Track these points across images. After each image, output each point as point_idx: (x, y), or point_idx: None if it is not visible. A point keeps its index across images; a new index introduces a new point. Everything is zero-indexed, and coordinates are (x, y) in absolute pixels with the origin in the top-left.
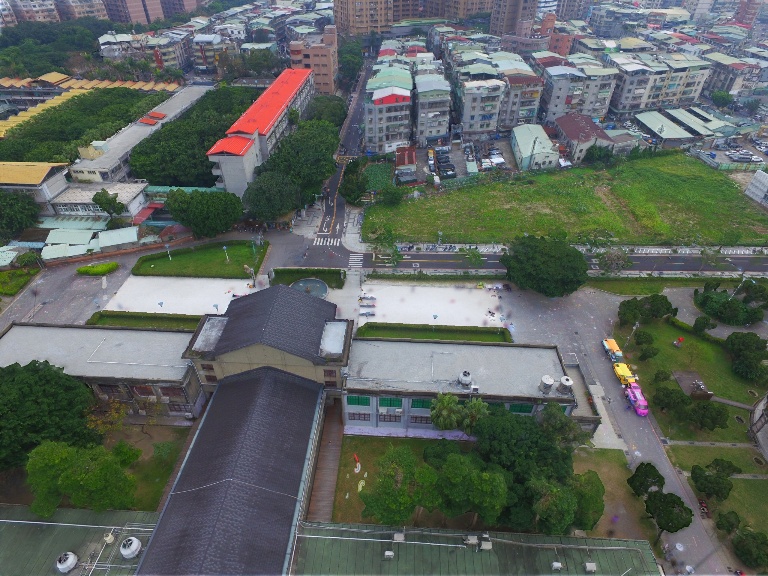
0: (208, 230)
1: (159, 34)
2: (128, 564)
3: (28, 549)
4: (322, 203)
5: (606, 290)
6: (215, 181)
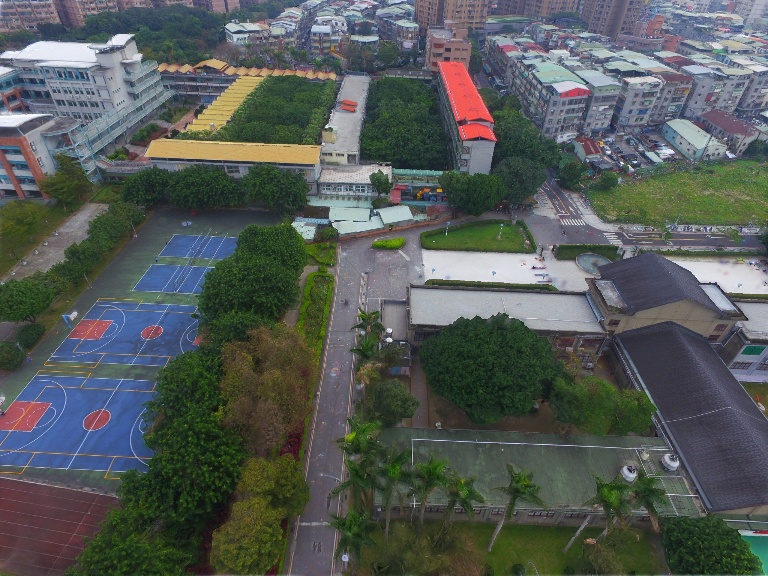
0: (482, 209)
1: None
2: (673, 475)
3: (580, 465)
4: (538, 188)
5: None
6: None
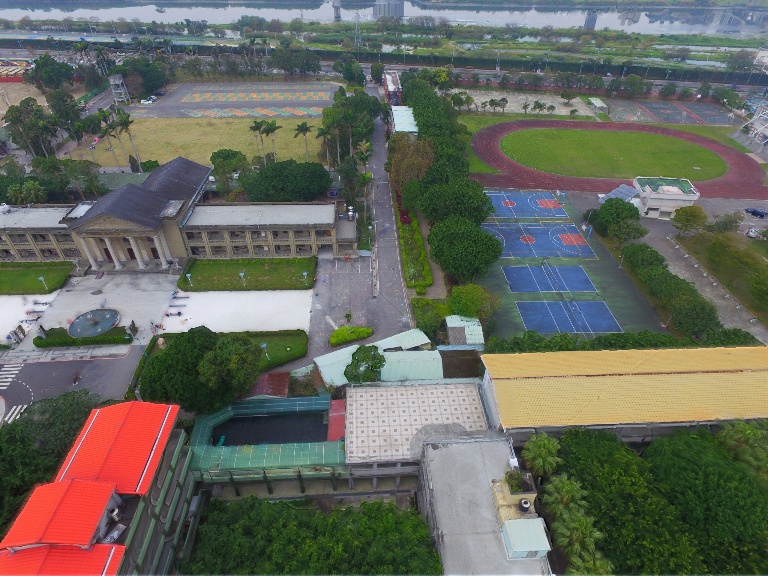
0: None
1: None
2: None
3: None
4: None
5: None
6: None
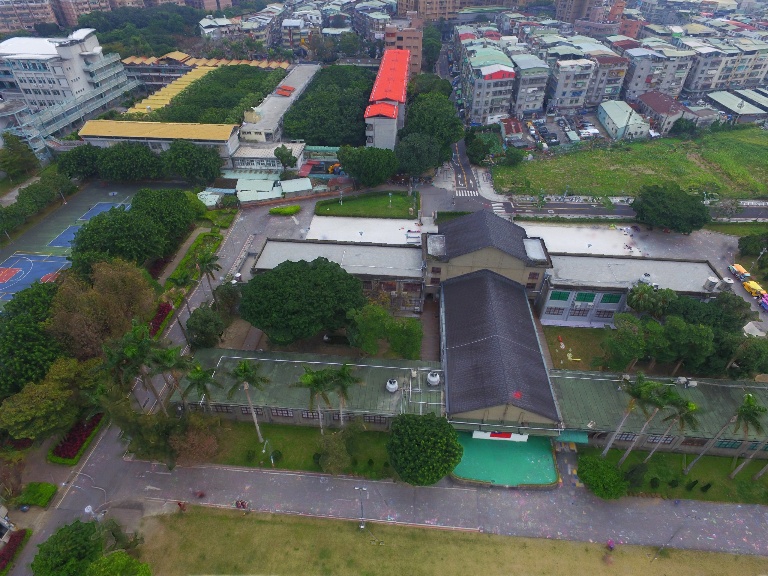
0: (374, 180)
1: (245, 19)
2: (434, 389)
3: None
4: (449, 164)
5: (720, 232)
6: (357, 143)
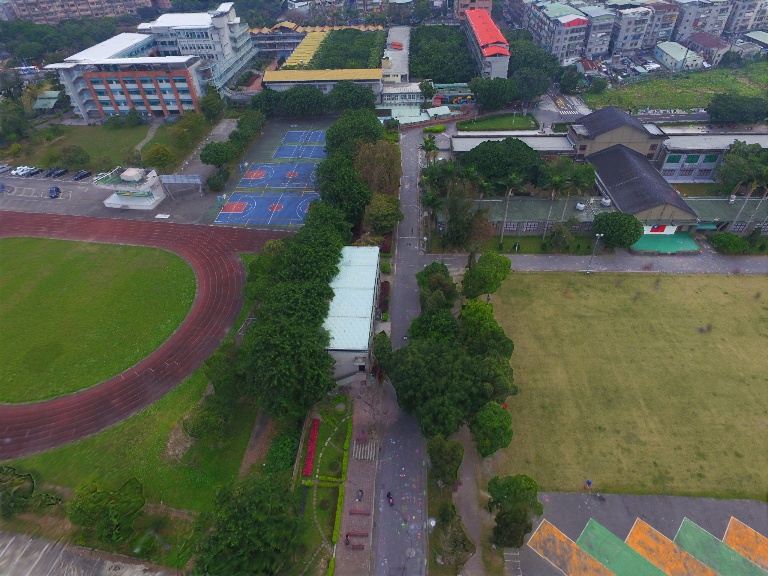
0: (500, 103)
1: None
2: (607, 208)
3: None
4: (545, 95)
5: None
6: None
